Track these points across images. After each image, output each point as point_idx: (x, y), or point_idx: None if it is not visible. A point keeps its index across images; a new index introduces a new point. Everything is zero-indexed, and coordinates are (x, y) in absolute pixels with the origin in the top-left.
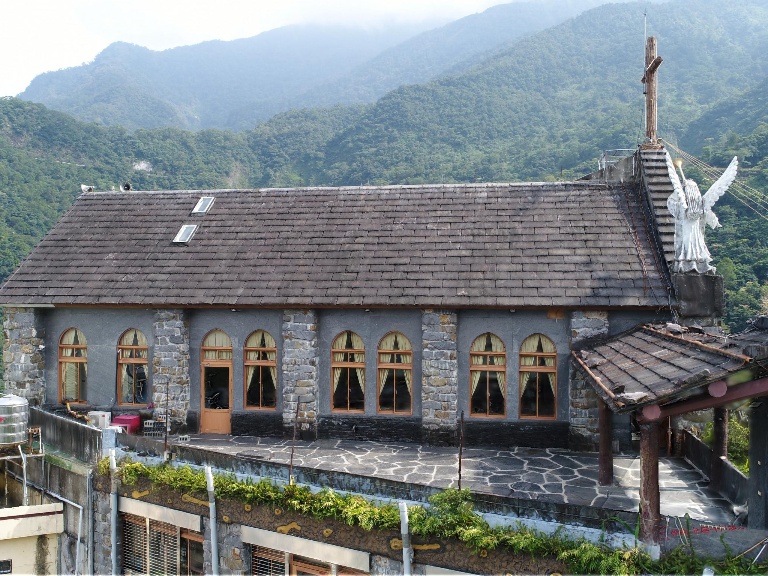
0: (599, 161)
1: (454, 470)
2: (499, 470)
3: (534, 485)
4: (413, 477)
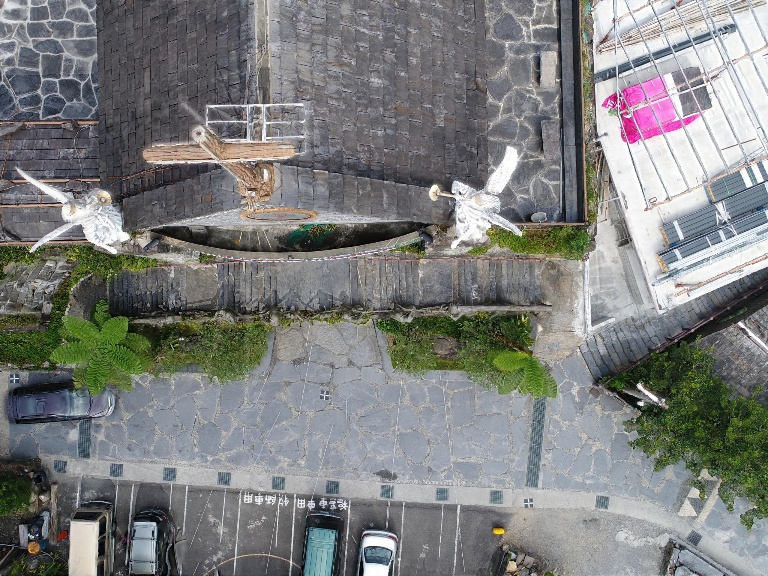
0: (295, 103)
1: (87, 52)
2: (93, 85)
3: (58, 110)
4: (63, 25)
